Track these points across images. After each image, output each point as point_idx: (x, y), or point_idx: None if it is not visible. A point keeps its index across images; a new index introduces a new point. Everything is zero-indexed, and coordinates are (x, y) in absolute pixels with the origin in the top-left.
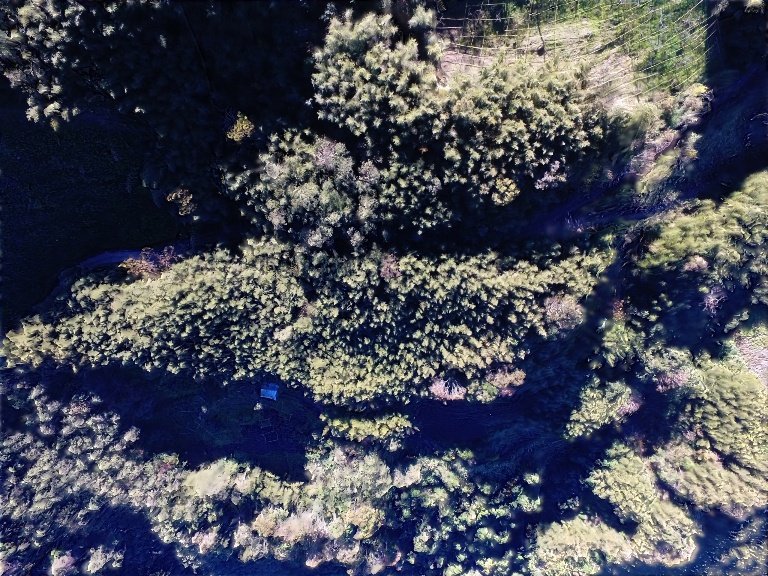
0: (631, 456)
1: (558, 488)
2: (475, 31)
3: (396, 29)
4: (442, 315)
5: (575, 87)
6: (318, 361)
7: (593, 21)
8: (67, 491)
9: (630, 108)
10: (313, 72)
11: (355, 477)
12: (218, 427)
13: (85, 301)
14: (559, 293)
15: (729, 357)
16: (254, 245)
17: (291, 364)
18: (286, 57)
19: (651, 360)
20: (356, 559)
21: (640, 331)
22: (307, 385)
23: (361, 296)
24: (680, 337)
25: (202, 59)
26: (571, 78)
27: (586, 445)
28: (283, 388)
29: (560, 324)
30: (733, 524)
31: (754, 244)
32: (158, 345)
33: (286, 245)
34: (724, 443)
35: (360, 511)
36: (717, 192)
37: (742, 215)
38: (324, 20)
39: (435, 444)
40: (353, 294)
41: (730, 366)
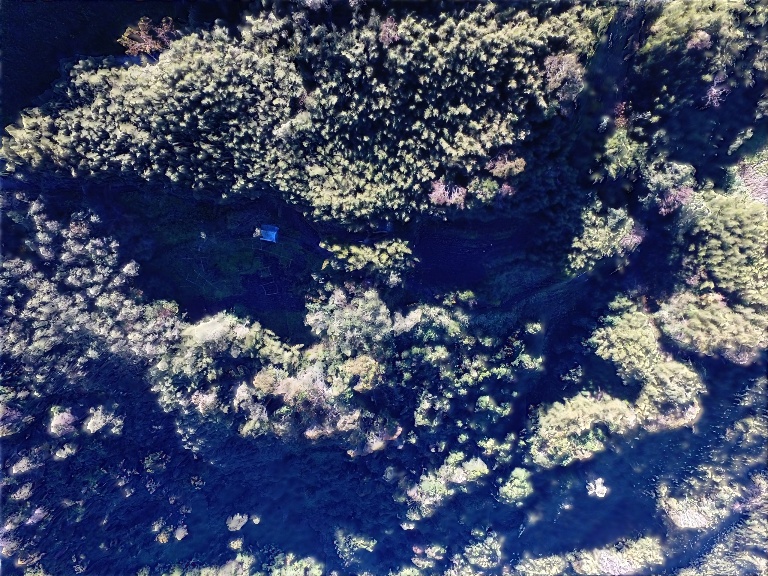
0: (634, 310)
1: (560, 359)
2: None
3: None
4: (441, 93)
5: None
6: (317, 169)
7: None
8: (67, 333)
9: None
10: None
11: (355, 315)
12: (218, 275)
13: (84, 89)
14: (559, 53)
15: (733, 189)
16: (252, 21)
17: (290, 172)
18: None
19: (654, 176)
20: (356, 426)
21: (642, 141)
22: (306, 197)
23: (360, 75)
24: (683, 149)
25: None
26: None
27: (588, 301)
28: (283, 229)
29: (560, 92)
30: (738, 386)
31: (757, 24)
32: (157, 142)
33: (284, 17)
34: (728, 279)
35: (360, 360)
36: None
37: None
38: None
39: (436, 289)
40: (352, 72)
41: (734, 198)
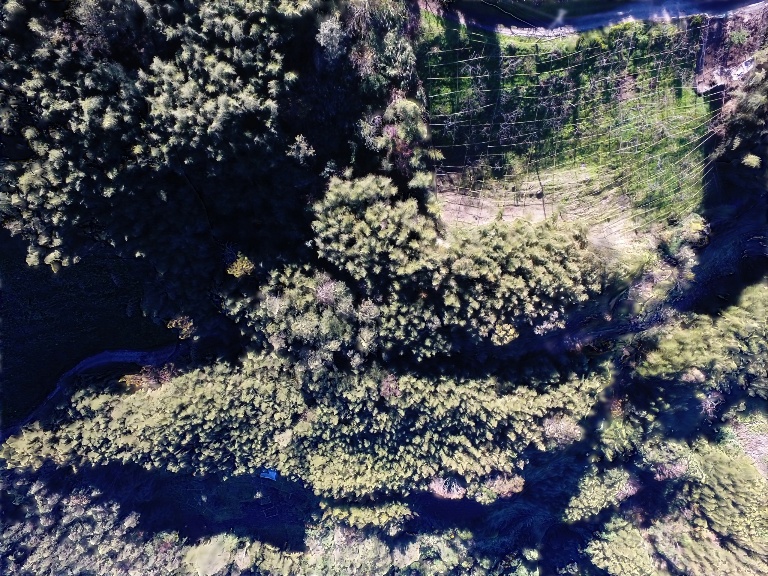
0: (629, 529)
1: (557, 553)
2: (474, 175)
3: (396, 189)
4: (442, 427)
5: (574, 247)
6: (318, 459)
7: (591, 167)
8: (67, 572)
9: (628, 257)
10: (313, 219)
11: (355, 559)
12: (218, 505)
13: (85, 410)
14: (558, 414)
15: (726, 441)
16: (254, 359)
17: (291, 462)
18: (286, 201)
19: (649, 452)
20: None
21: (638, 426)
22: (307, 480)
23: (361, 408)
24: (678, 431)
25: (202, 204)
26: (570, 241)
27: None
28: None
29: (559, 440)
30: None
31: (751, 354)
32: (158, 449)
33: (286, 361)
34: (721, 525)
35: None
36: (714, 305)
37: (739, 329)
38: (324, 177)
39: (434, 522)
40: (353, 407)
41: (727, 450)
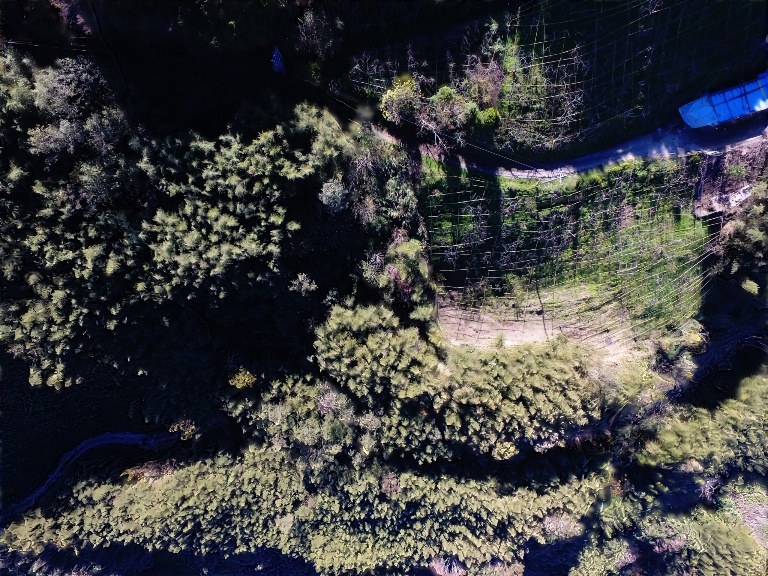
0: None
1: None
2: (475, 293)
3: (397, 320)
4: None
5: (574, 377)
6: (319, 538)
7: (591, 285)
8: None
9: (628, 378)
10: (315, 339)
11: None
12: (219, 569)
13: (87, 498)
14: (558, 512)
15: (725, 509)
16: (256, 452)
17: (292, 541)
18: (288, 319)
19: (648, 527)
20: None
21: (637, 503)
22: (308, 558)
23: (362, 499)
24: (676, 507)
25: (204, 322)
26: (570, 374)
27: None
28: None
29: None
30: None
31: (749, 443)
32: None
33: (287, 456)
34: None
35: None
36: (713, 396)
37: (737, 422)
38: (326, 305)
39: None
40: (354, 498)
41: (726, 518)
